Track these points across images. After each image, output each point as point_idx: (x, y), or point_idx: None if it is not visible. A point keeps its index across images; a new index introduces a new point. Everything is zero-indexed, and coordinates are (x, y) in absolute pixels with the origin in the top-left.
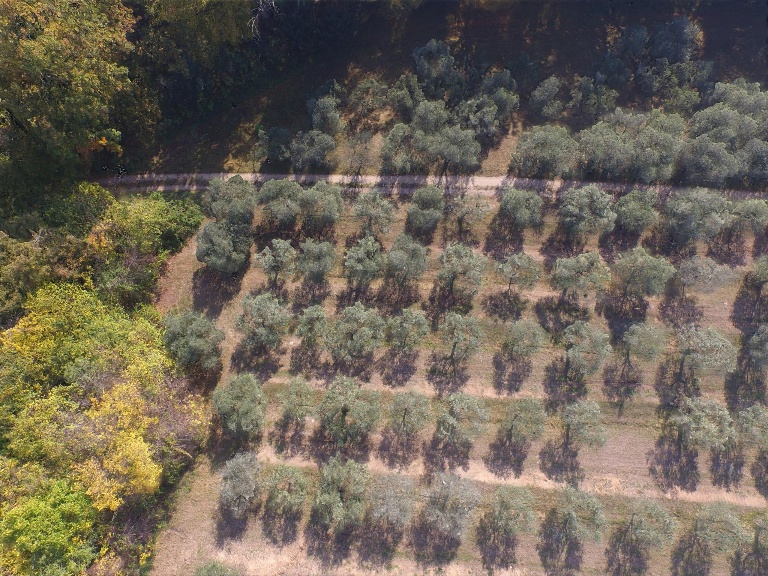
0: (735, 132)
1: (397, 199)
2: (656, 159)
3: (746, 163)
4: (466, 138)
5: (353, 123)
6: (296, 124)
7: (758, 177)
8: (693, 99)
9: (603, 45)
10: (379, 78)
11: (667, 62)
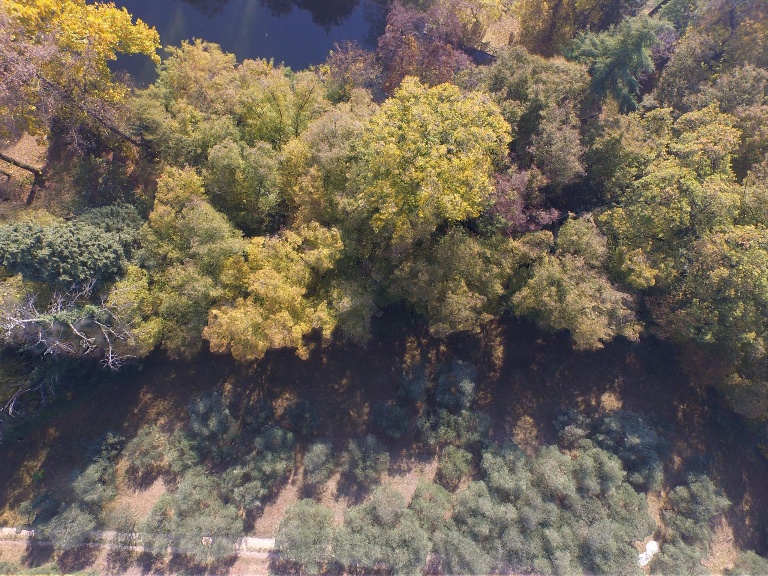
0: (491, 524)
1: (166, 565)
2: (405, 562)
3: (499, 561)
4: (218, 530)
5: (136, 465)
6: (78, 466)
7: (516, 567)
8: (461, 468)
9: (399, 366)
10: (169, 407)
11: (444, 416)
